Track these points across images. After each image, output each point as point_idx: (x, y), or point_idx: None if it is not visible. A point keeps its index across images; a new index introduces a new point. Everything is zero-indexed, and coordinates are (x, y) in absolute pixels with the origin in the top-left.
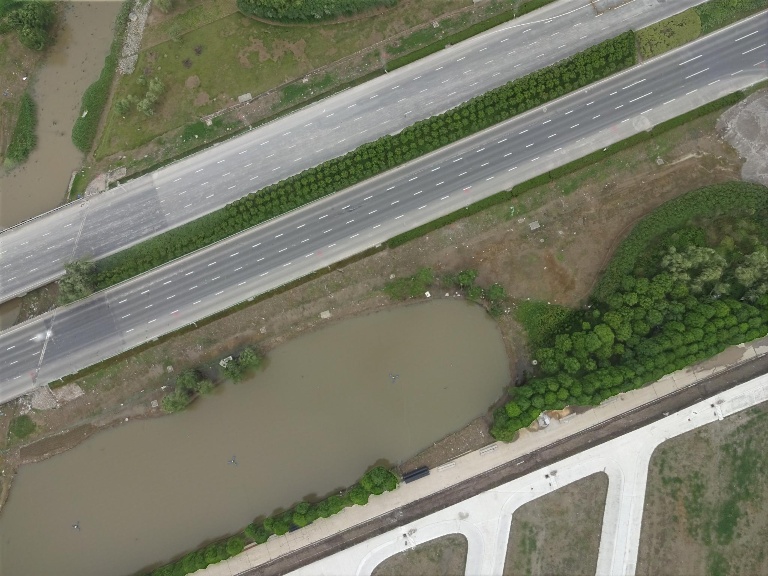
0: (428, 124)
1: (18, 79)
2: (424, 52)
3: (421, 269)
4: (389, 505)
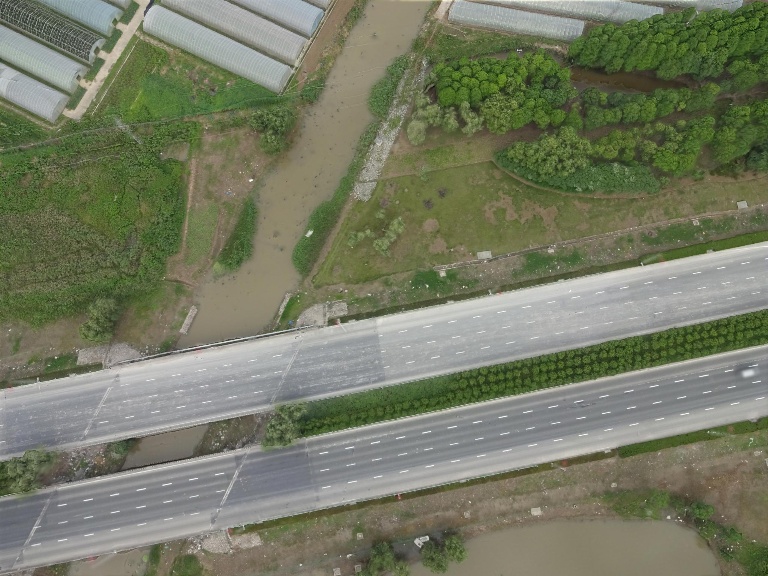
0: (682, 334)
1: (244, 179)
2: (685, 253)
3: (657, 493)
4: None
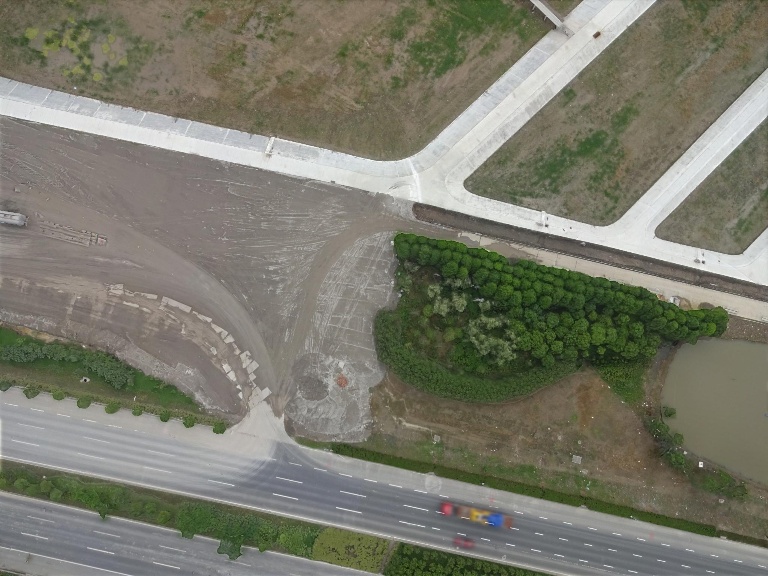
0: None
1: None
2: None
3: None
4: None
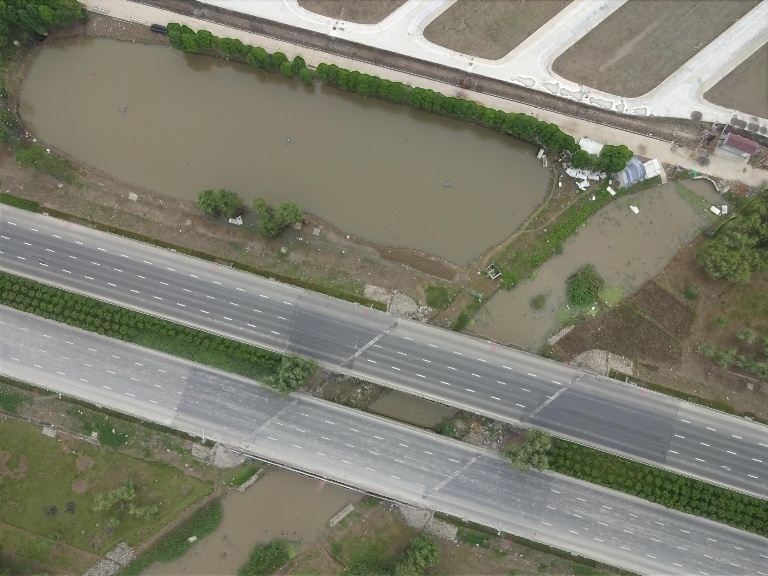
0: None
1: None
2: None
3: None
4: (200, 25)
